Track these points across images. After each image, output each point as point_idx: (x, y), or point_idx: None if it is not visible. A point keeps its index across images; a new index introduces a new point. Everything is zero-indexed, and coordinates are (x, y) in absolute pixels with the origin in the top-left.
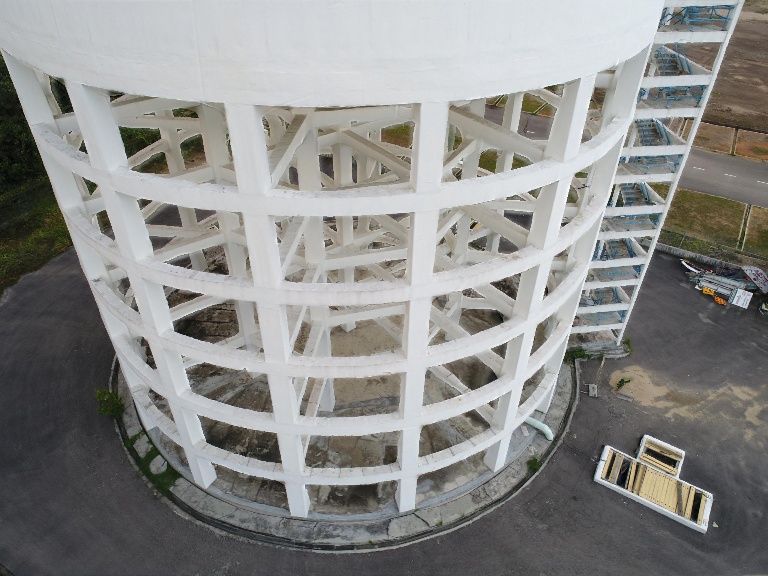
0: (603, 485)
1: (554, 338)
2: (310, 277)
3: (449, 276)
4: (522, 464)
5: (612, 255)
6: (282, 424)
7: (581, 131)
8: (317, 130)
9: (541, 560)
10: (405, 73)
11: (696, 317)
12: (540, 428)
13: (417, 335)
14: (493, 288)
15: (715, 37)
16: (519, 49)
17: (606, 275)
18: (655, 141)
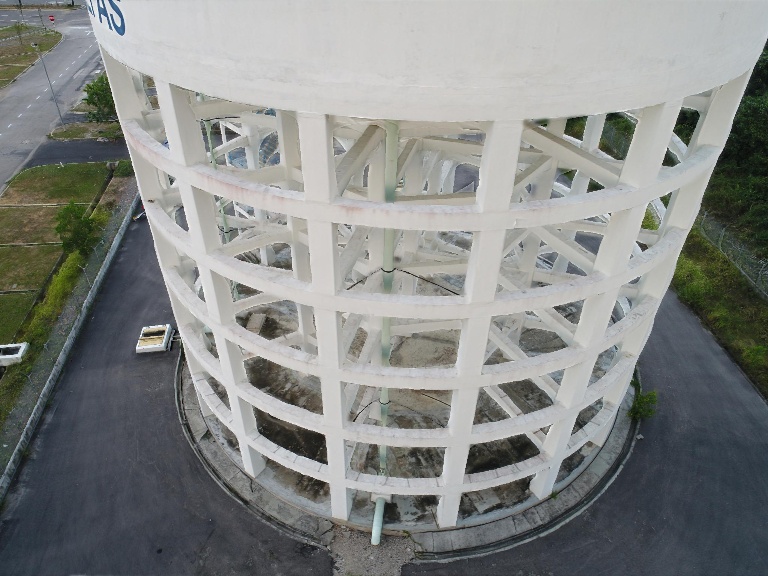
0: None
1: None
2: None
3: None
4: None
5: None
6: None
7: None
8: None
9: None
10: None
11: None
12: None
13: None
14: None
15: None
16: None
17: None
18: None
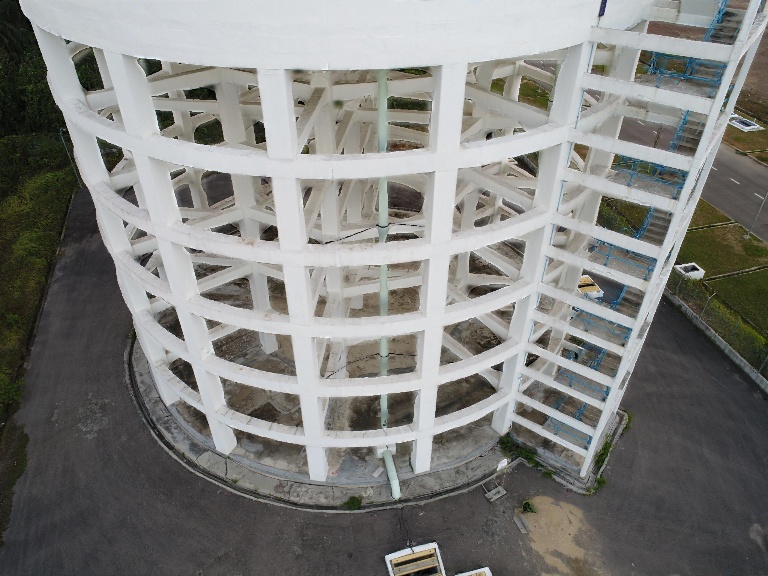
0: None
1: (383, 380)
2: (220, 213)
3: (183, 229)
4: (346, 495)
5: (599, 362)
6: (131, 308)
7: (286, 131)
8: (232, 85)
9: (263, 569)
10: (85, 19)
11: (745, 524)
12: (390, 479)
13: (172, 274)
14: (314, 288)
15: (694, 104)
16: (165, 18)
17: None
18: (664, 236)
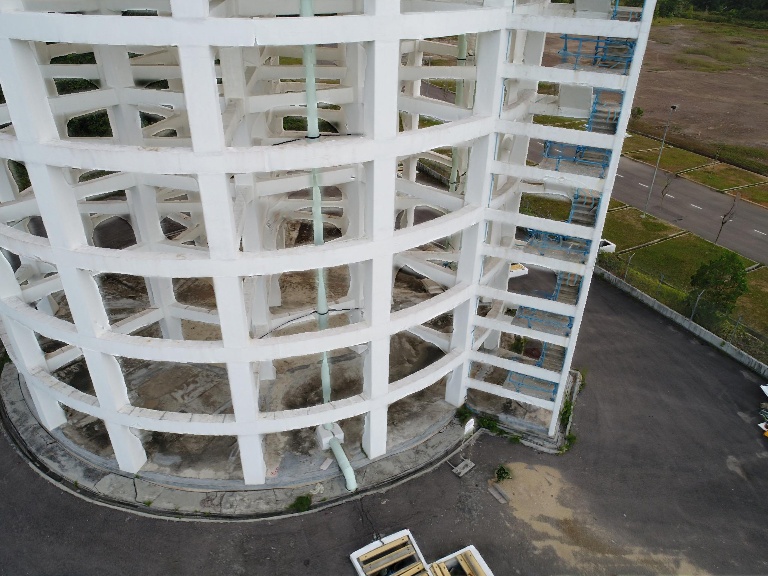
0: (355, 569)
1: (327, 332)
2: (107, 177)
3: (62, 144)
4: (292, 496)
5: (554, 300)
6: None
7: None
8: None
9: None
10: None
11: (720, 457)
12: (342, 468)
13: (49, 215)
14: None
15: None
16: None
17: (528, 320)
18: None
